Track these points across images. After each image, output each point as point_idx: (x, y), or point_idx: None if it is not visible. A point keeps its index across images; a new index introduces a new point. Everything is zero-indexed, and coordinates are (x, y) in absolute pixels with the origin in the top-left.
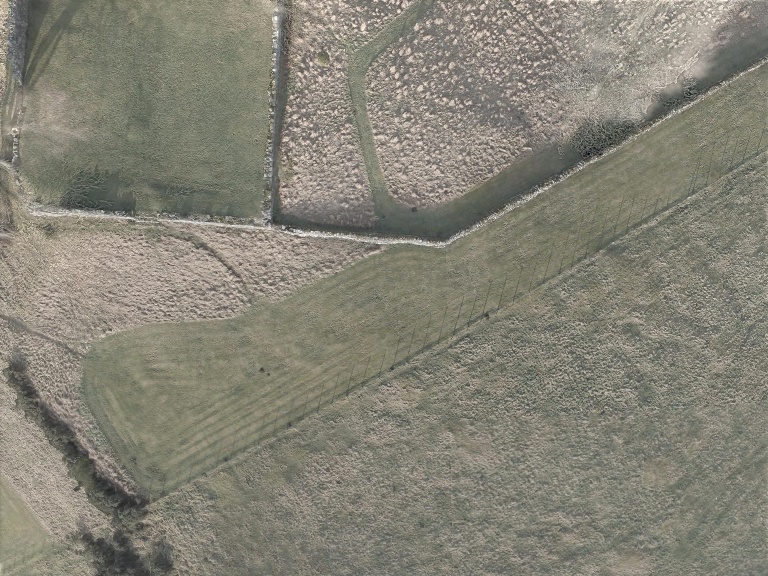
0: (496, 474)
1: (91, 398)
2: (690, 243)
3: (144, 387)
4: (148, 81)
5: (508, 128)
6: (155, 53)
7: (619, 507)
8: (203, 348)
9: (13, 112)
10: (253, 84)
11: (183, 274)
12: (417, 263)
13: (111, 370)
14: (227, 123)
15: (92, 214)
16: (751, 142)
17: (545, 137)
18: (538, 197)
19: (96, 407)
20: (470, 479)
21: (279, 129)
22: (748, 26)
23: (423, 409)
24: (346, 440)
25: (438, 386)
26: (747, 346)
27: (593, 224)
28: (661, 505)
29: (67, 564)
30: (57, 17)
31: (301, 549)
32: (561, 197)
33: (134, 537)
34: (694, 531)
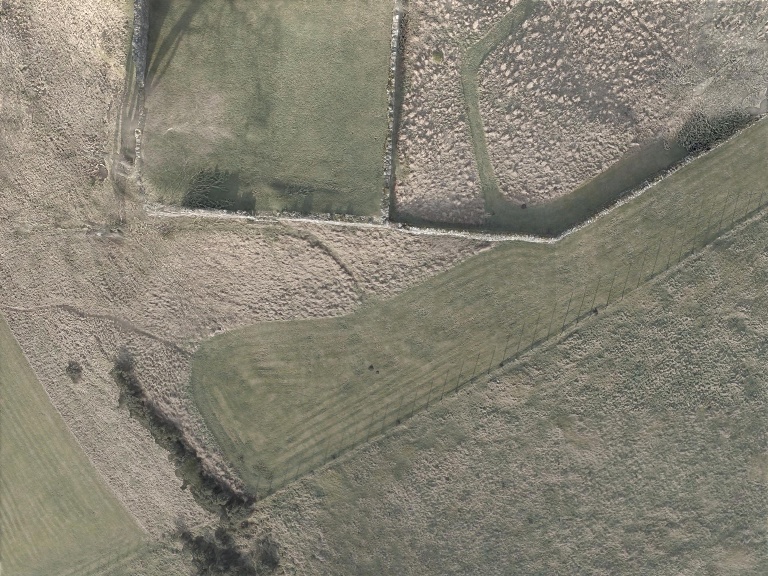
0: (604, 470)
1: (199, 397)
2: None
3: (253, 386)
4: (266, 81)
5: (616, 124)
6: (273, 53)
7: (725, 502)
8: (313, 346)
9: (134, 113)
10: (372, 83)
11: (296, 273)
12: (527, 260)
13: (219, 369)
14: (346, 122)
15: (214, 214)
16: None
17: (652, 133)
18: (646, 193)
19: (204, 406)
20: (578, 475)
21: (396, 127)
22: None
23: (532, 405)
24: (455, 437)
25: (547, 382)
26: None
27: (699, 219)
28: (766, 500)
29: (162, 563)
30: (177, 19)
31: (410, 546)
32: (668, 192)
33: (236, 535)
34: None
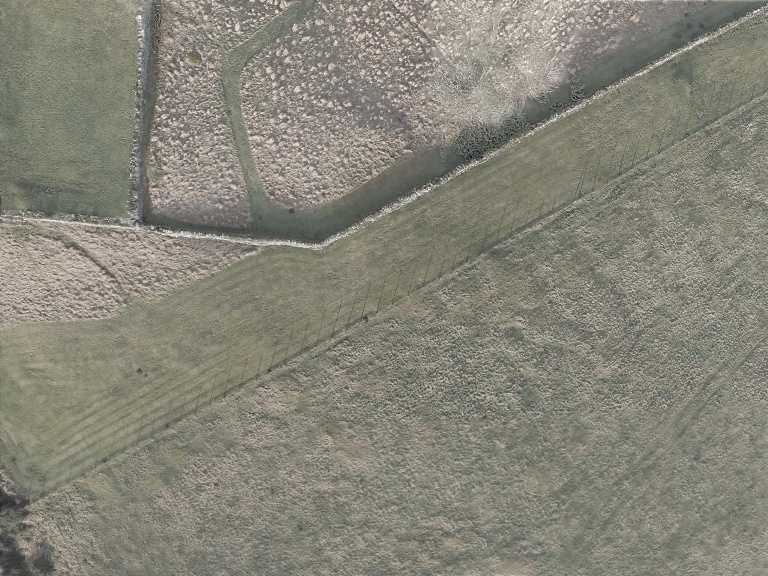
0: (376, 478)
1: None
2: (576, 247)
3: (22, 387)
4: (15, 79)
5: (387, 130)
6: (23, 51)
7: (502, 512)
8: (80, 348)
9: None
10: (120, 83)
11: (56, 273)
12: (294, 265)
13: None
14: (94, 122)
15: None
16: (640, 147)
17: (426, 140)
18: (418, 200)
19: None
20: (349, 482)
21: (148, 129)
22: (639, 31)
23: (301, 412)
24: (224, 442)
25: (316, 389)
26: (635, 351)
27: (476, 227)
28: (545, 510)
29: None
30: None
31: (178, 551)
32: (442, 200)
33: (19, 538)
34: (579, 537)
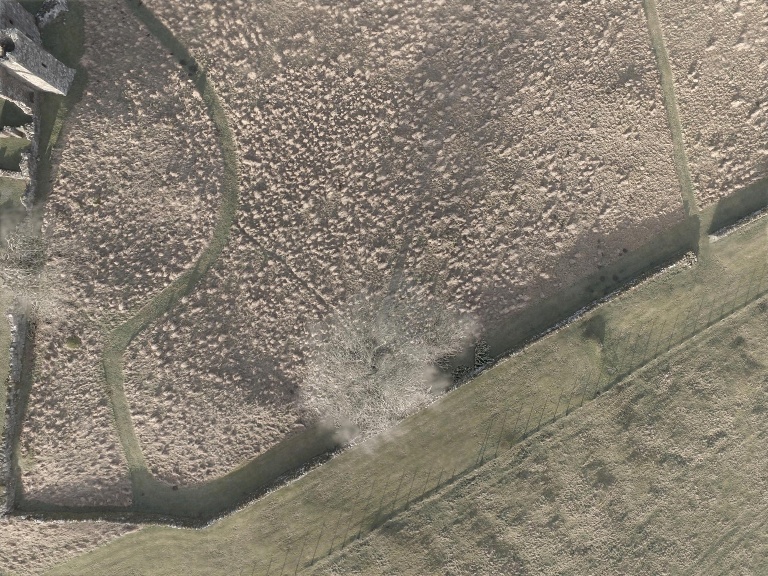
0: None
1: None
2: (477, 515)
3: None
4: None
5: (278, 405)
6: None
7: None
8: None
9: None
10: None
11: None
12: (177, 543)
13: None
14: None
15: None
16: (547, 408)
17: (319, 412)
18: (309, 475)
19: None
20: None
21: (21, 418)
22: (550, 286)
23: None
24: None
25: None
26: None
27: (370, 500)
28: None
29: None
30: None
31: None
32: (335, 473)
33: None
34: None
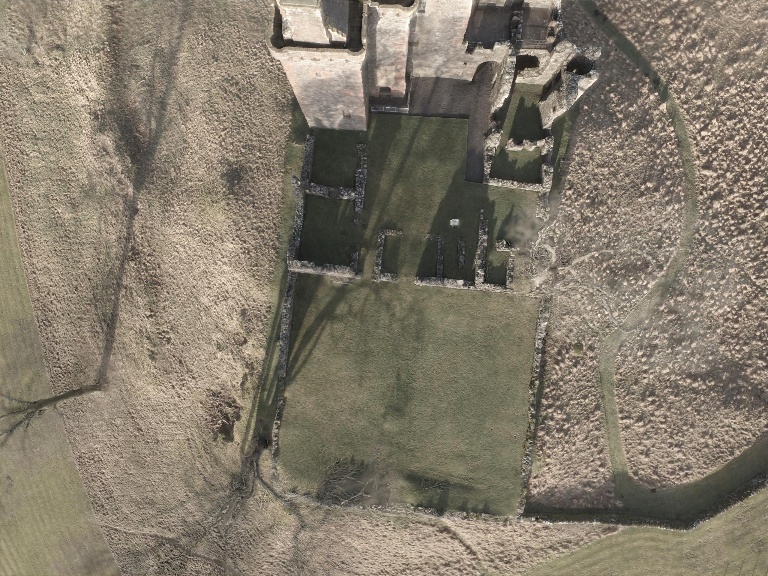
0: None
1: None
2: None
3: None
4: (406, 371)
5: (750, 409)
6: (414, 343)
7: None
8: None
9: (271, 399)
10: (513, 380)
11: (421, 551)
12: (654, 544)
13: None
14: (485, 418)
15: None
16: None
17: None
18: None
19: None
20: None
21: None
22: None
23: None
24: None
25: None
26: None
27: None
28: None
29: None
30: (321, 308)
31: None
32: None
33: None
34: None
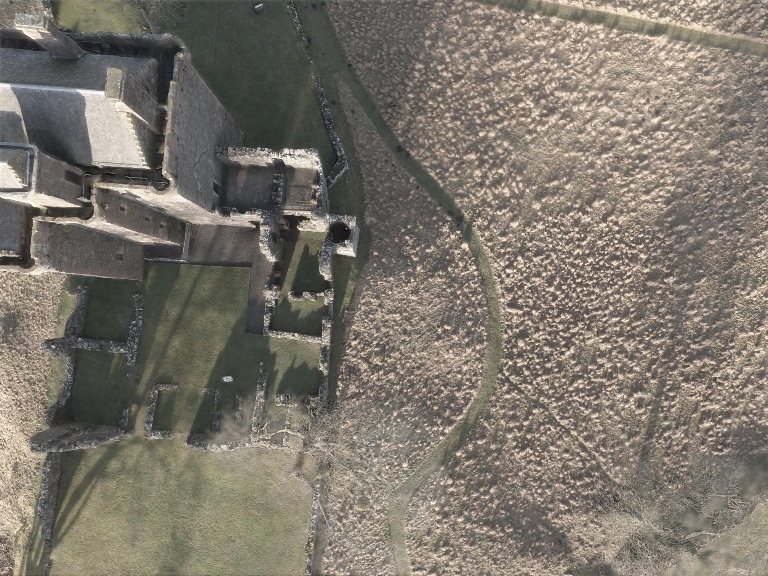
0: None
1: None
2: None
3: None
4: (181, 529)
5: (549, 556)
6: (190, 500)
7: None
8: None
9: (39, 560)
10: (290, 540)
11: None
12: None
13: None
14: None
15: None
16: None
17: (586, 561)
18: None
19: None
20: None
21: None
22: None
23: None
24: None
25: None
26: None
27: None
28: None
29: None
30: (91, 466)
31: None
32: None
33: None
34: None
